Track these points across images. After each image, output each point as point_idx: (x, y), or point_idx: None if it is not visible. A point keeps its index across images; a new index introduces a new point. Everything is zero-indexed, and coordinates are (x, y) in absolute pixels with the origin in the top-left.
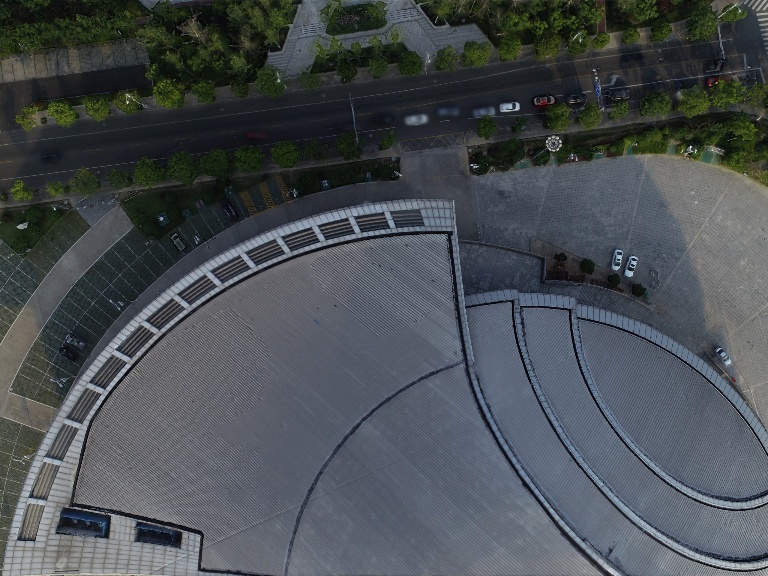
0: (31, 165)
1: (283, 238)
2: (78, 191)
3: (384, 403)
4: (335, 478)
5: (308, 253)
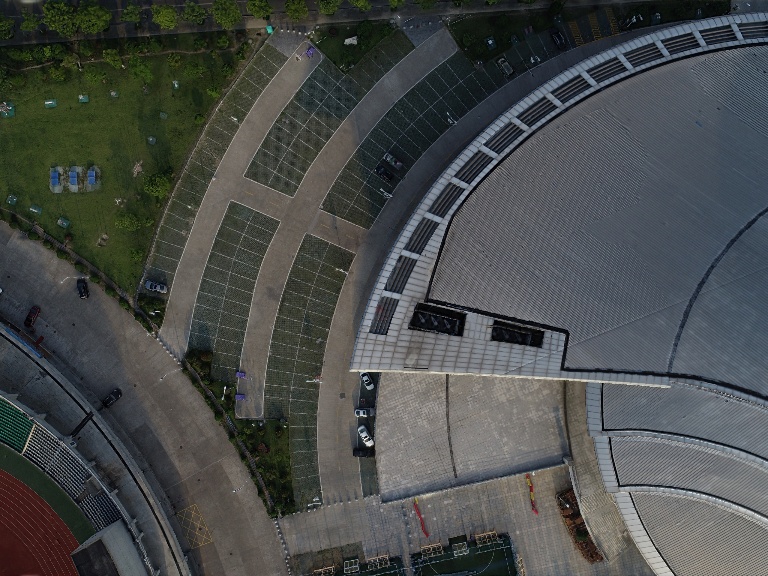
0: None
1: (661, 42)
2: (405, 11)
3: None
4: (731, 271)
5: (688, 57)
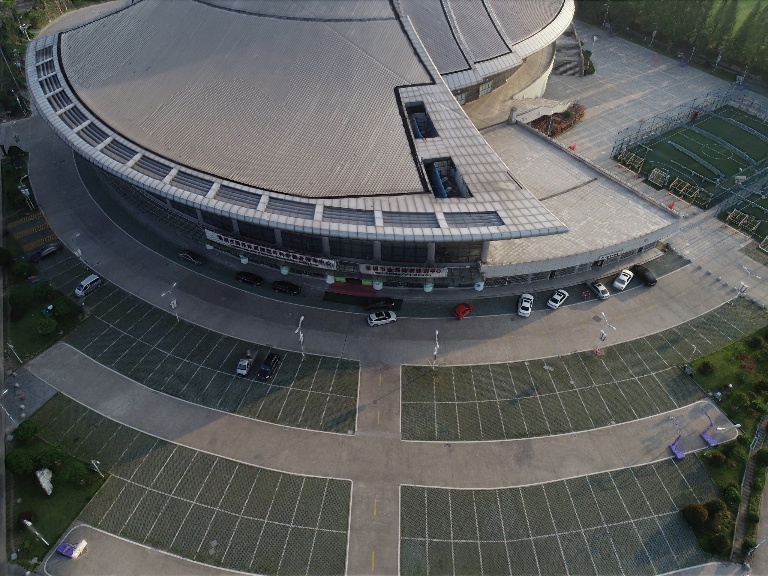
0: None
1: None
2: None
3: (212, 5)
4: (287, 8)
5: None
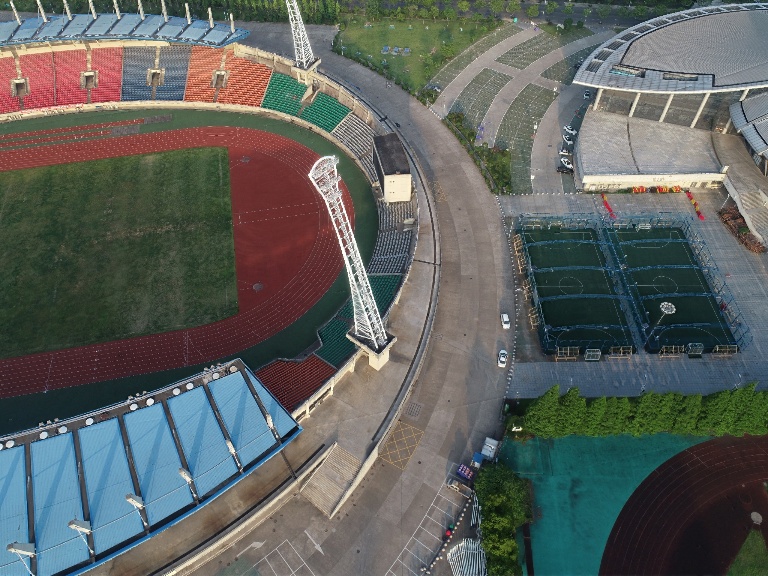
0: (564, 15)
1: None
2: (589, 24)
3: None
4: None
5: None
